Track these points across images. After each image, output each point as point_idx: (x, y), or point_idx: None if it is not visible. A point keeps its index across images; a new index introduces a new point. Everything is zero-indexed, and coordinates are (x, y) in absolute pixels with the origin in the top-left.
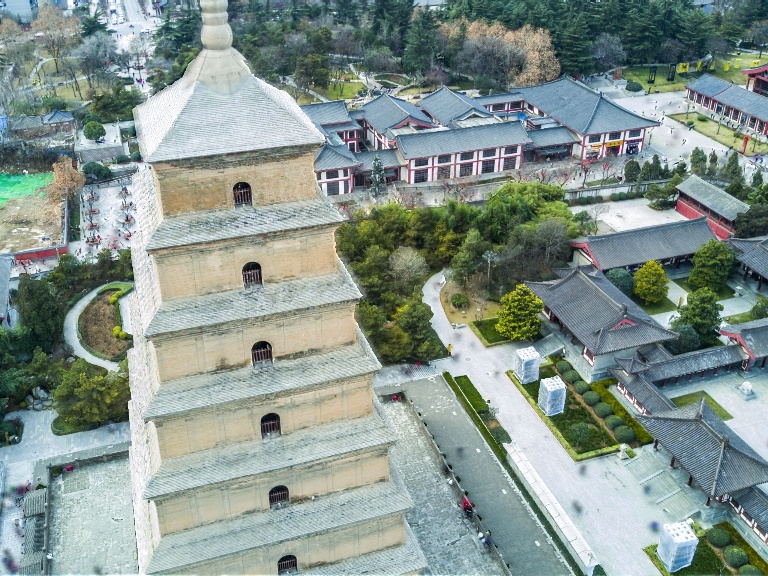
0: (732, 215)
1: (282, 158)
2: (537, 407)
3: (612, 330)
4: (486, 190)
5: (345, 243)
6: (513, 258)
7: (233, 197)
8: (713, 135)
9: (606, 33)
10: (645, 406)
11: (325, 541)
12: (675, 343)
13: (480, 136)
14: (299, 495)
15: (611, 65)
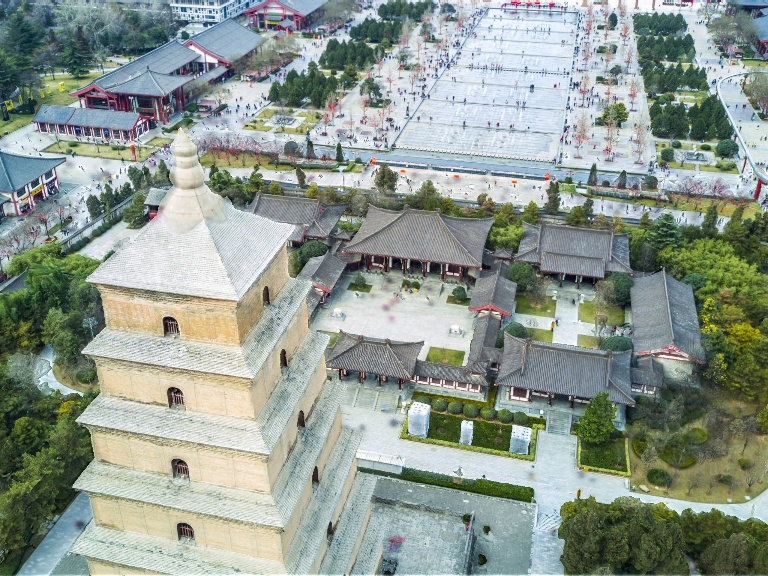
0: None
1: None
2: None
3: None
4: None
5: None
6: None
7: None
8: (97, 155)
9: None
10: None
11: None
12: None
13: None
14: (335, 523)
15: None
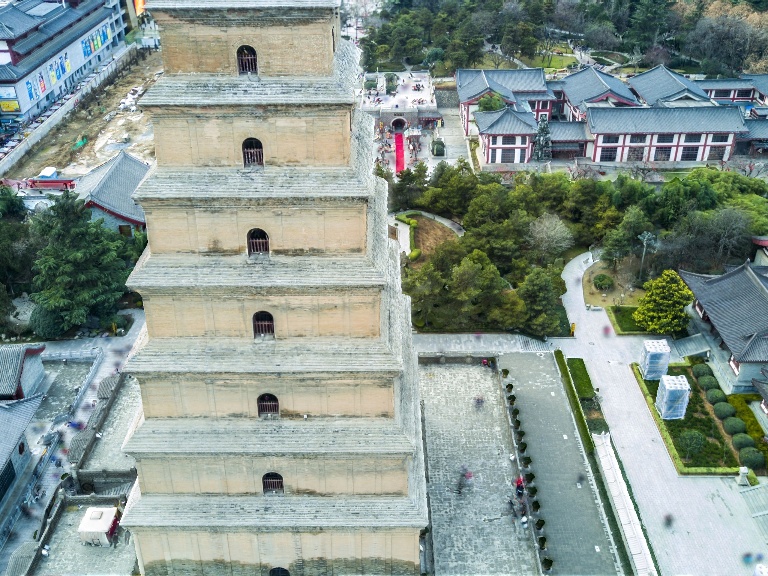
0: None
1: (291, 22)
2: (653, 407)
3: None
4: (681, 178)
5: (489, 202)
6: None
7: (240, 63)
8: None
9: None
10: None
11: (315, 467)
12: None
13: (685, 118)
14: (290, 409)
15: None
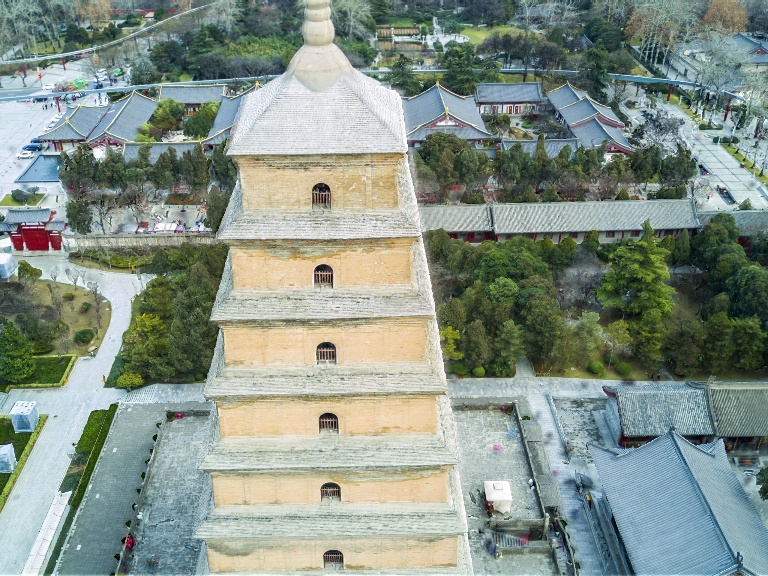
0: None
1: None
2: None
3: None
4: None
5: None
6: None
7: None
8: None
9: None
10: None
11: None
12: None
13: None
14: None
15: None
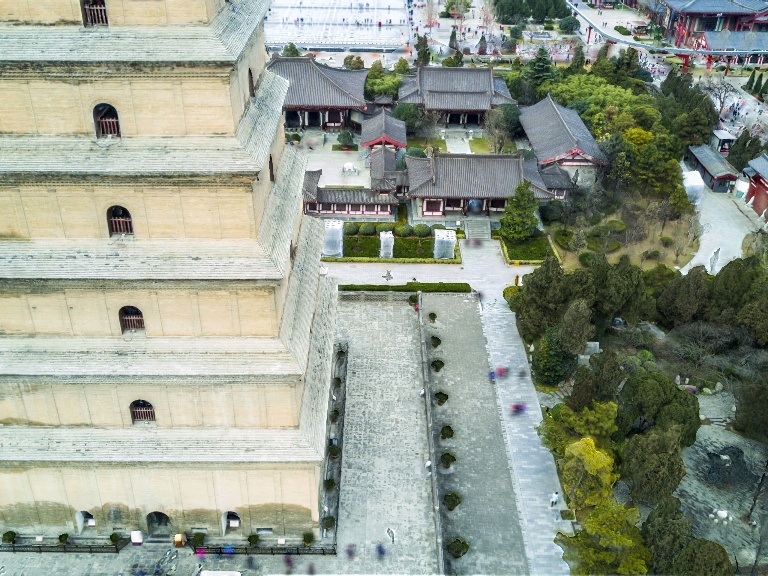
0: None
1: None
2: None
3: None
4: None
5: None
6: None
7: None
8: None
9: None
10: None
11: None
12: None
13: None
14: (294, 246)
15: None
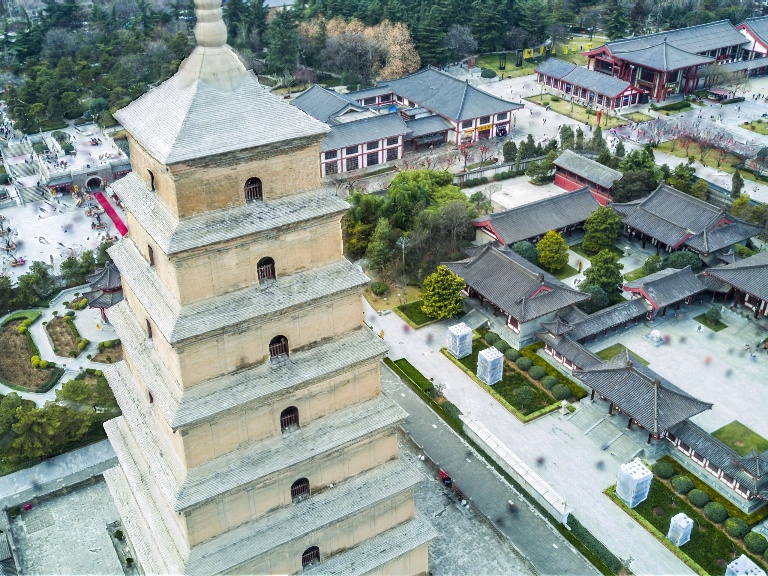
0: (608, 183)
1: (290, 150)
2: (477, 378)
3: (533, 298)
4: (374, 182)
5: None
6: (420, 243)
7: None
8: (568, 113)
9: (456, 24)
10: (576, 363)
11: (345, 527)
12: (587, 303)
13: (362, 130)
14: (319, 485)
15: (464, 55)
